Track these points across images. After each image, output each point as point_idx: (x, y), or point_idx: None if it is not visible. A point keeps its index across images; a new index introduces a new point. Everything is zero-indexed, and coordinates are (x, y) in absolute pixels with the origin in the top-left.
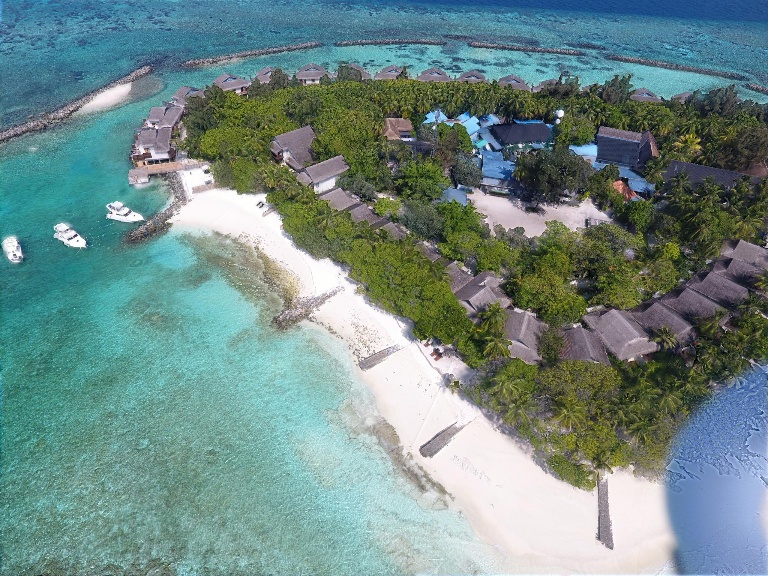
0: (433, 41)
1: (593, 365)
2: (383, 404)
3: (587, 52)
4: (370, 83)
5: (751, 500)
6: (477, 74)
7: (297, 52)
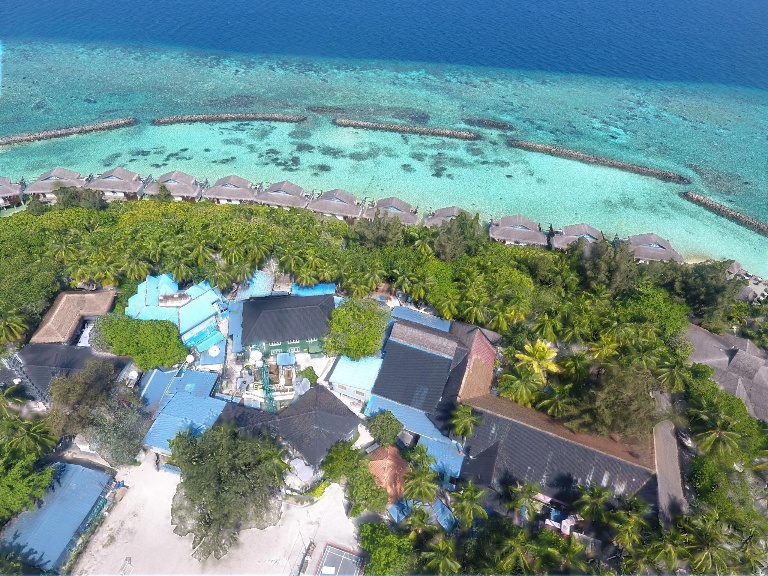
0: (287, 117)
1: None
2: None
3: (486, 134)
4: (116, 207)
5: None
6: (288, 187)
7: (91, 135)
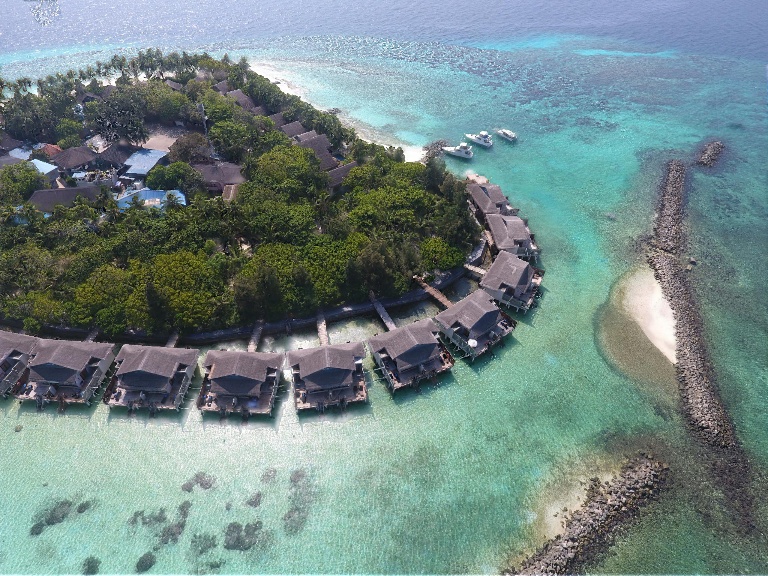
0: None
1: None
2: (291, 91)
3: None
4: None
5: None
6: None
7: None
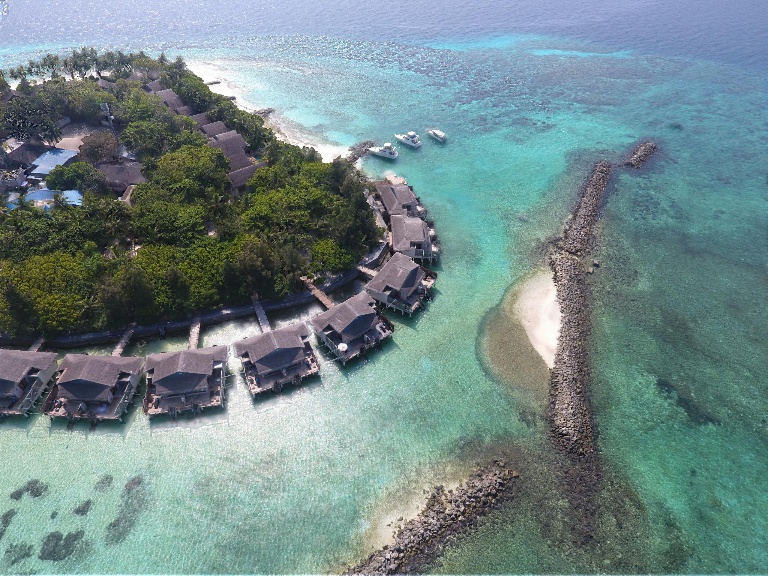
0: None
1: (141, 62)
2: (230, 91)
3: None
4: None
5: None
6: None
7: None
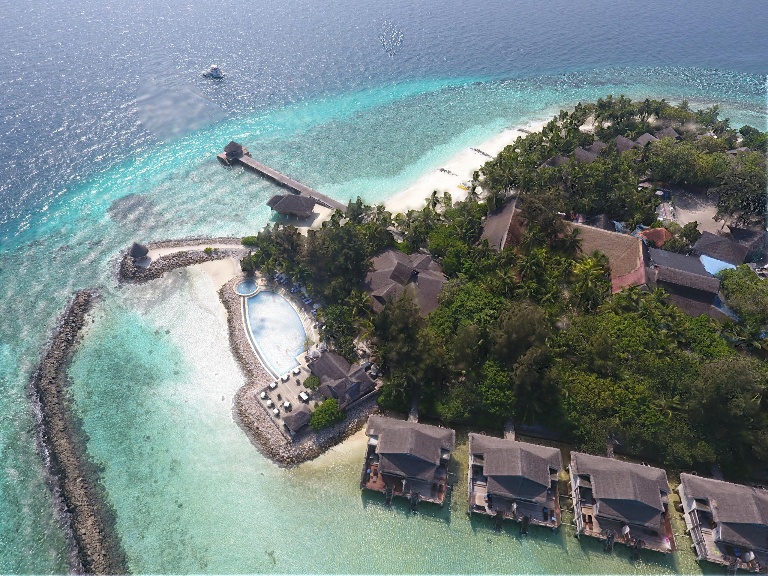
0: None
1: (678, 112)
2: None
3: None
4: None
5: (587, 119)
6: None
7: None
